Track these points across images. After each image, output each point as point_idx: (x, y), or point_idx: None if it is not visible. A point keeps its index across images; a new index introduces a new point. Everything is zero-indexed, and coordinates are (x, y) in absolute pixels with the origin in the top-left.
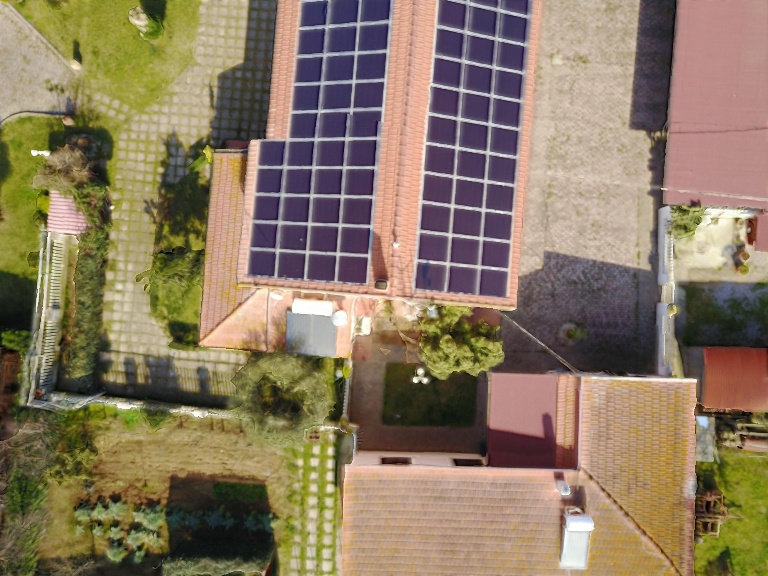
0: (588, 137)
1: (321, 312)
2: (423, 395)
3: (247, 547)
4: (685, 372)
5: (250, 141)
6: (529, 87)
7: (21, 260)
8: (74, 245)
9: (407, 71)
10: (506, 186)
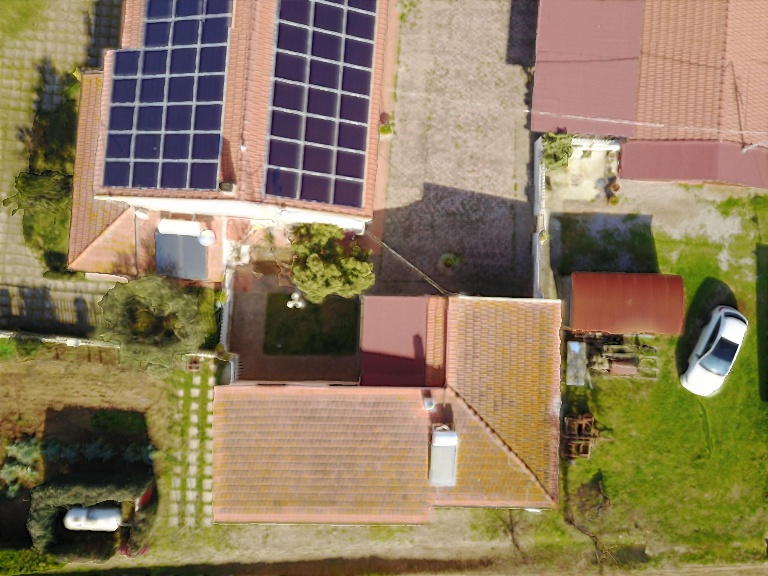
0: (467, 71)
1: (189, 232)
2: (304, 325)
3: (121, 477)
4: None
5: None
6: (384, 1)
7: None
8: None
9: None
10: (361, 97)
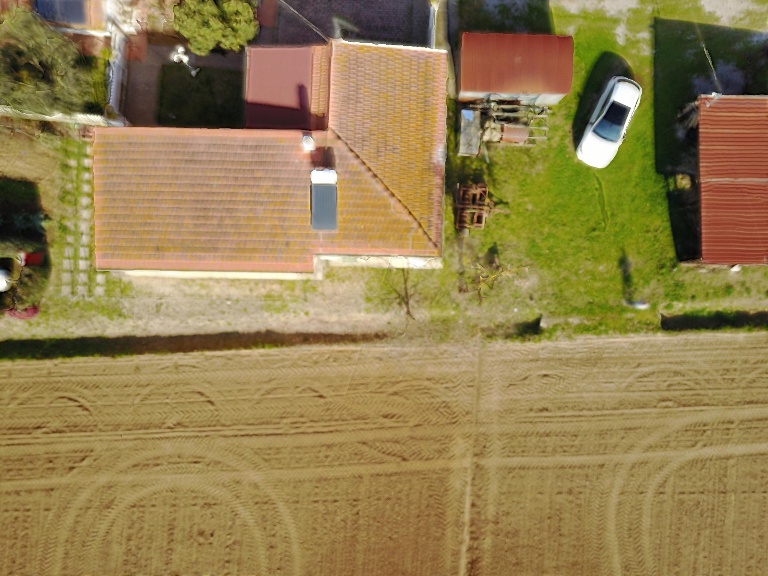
0: None
1: None
2: (199, 97)
3: (10, 237)
4: (456, 73)
5: None
6: None
7: None
8: None
9: None
10: None
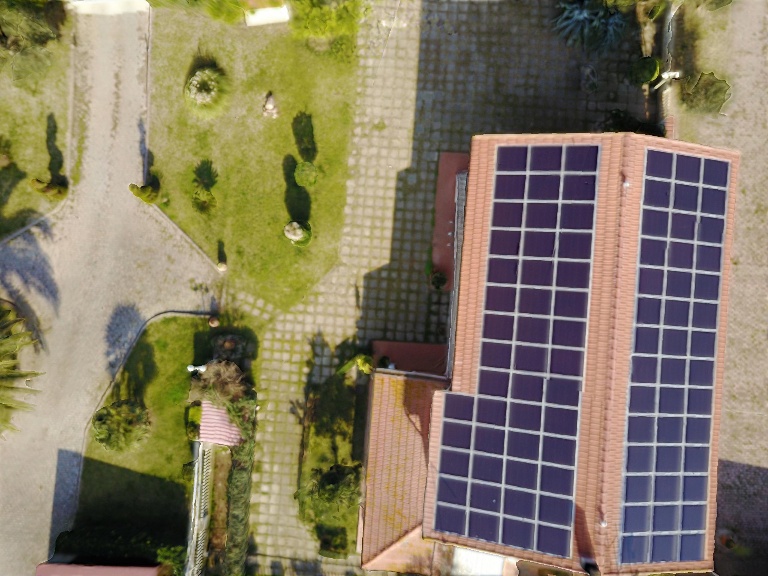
0: (741, 339)
1: None
2: None
3: None
4: None
5: (434, 392)
6: (723, 344)
7: (168, 463)
8: (220, 446)
9: (611, 344)
10: (703, 447)
